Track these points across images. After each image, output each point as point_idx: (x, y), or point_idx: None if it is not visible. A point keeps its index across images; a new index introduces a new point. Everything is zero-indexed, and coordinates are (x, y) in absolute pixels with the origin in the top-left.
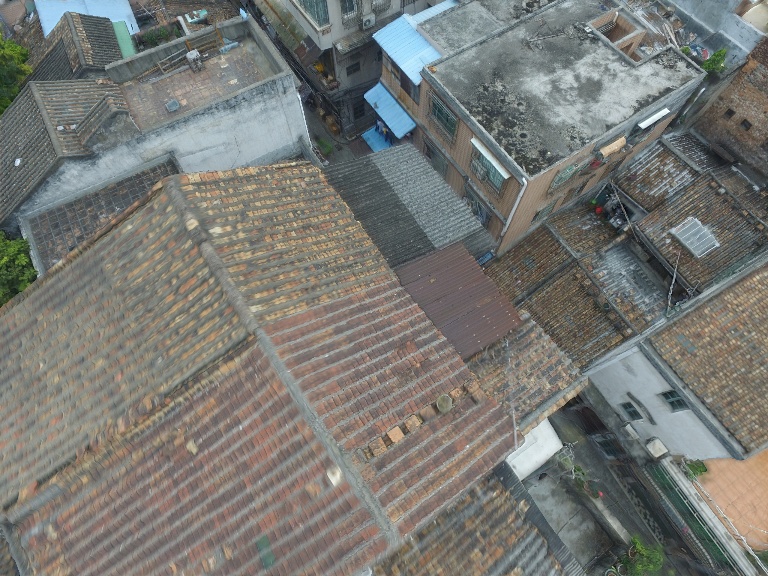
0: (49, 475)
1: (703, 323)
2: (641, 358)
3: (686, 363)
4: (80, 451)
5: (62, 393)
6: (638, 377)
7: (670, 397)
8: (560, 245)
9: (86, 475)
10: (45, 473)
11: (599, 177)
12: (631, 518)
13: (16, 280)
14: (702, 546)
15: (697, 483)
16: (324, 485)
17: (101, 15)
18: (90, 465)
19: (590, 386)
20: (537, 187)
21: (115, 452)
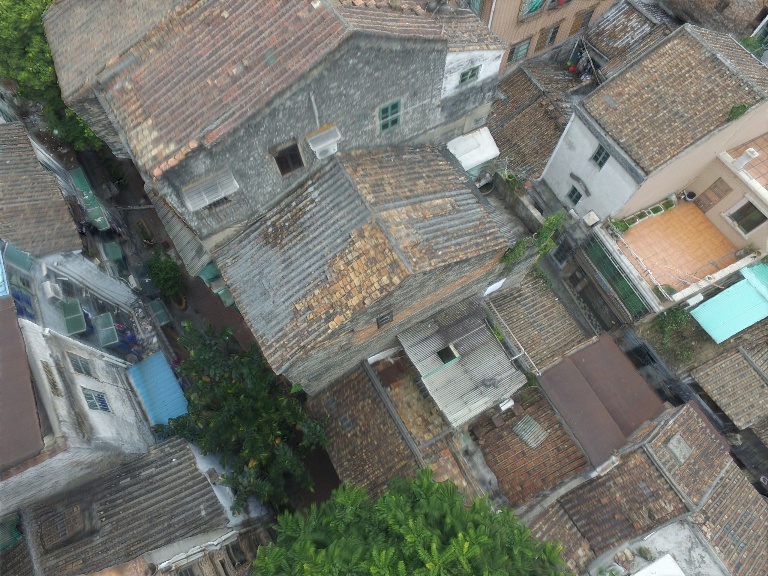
0: (127, 49)
1: (624, 84)
2: (577, 125)
3: (608, 116)
4: (149, 30)
5: (137, 4)
6: (576, 150)
7: (598, 157)
8: (531, 83)
9: (152, 47)
10: (125, 49)
11: (570, 27)
12: (577, 319)
13: None
14: (625, 306)
15: (618, 235)
16: (309, 12)
17: None
18: (156, 38)
19: (545, 187)
20: (507, 5)
21: (173, 28)
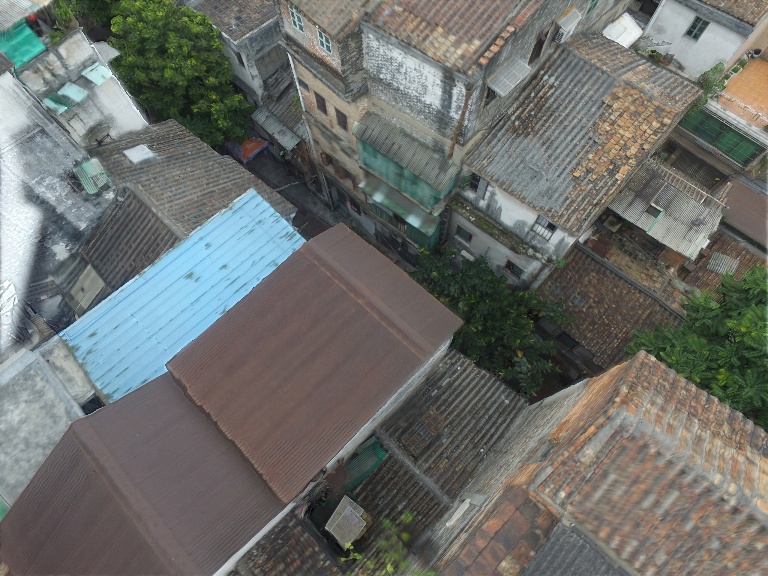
0: None
1: None
2: (669, 7)
3: None
4: None
5: None
6: (667, 31)
7: (693, 30)
8: None
9: None
10: None
11: None
12: None
13: (208, 36)
14: (731, 159)
15: (722, 93)
16: None
17: None
18: None
19: None
20: None
21: None
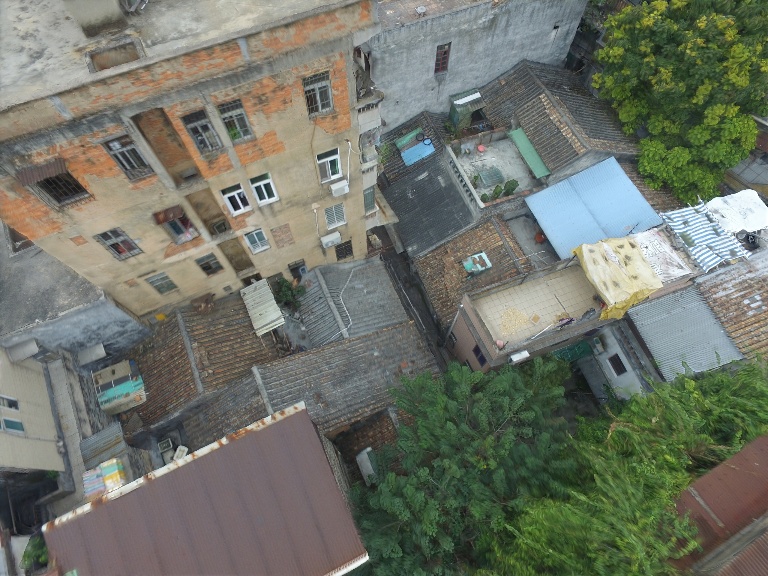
0: None
1: None
2: None
3: None
4: None
5: None
6: None
7: None
8: None
9: None
10: None
11: None
12: None
13: None
14: None
15: None
16: None
17: (578, 218)
18: None
19: None
20: None
21: None
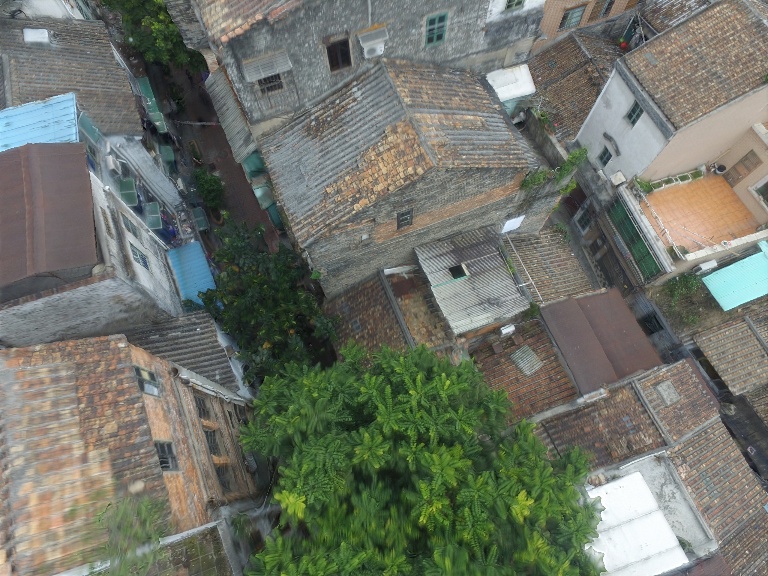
0: None
1: (668, 43)
2: (616, 82)
3: (648, 73)
4: None
5: None
6: (613, 107)
7: (633, 115)
8: (580, 50)
9: None
10: None
11: (627, 1)
12: None
13: None
14: (639, 269)
15: (641, 194)
16: None
17: None
18: None
19: (578, 149)
20: None
21: None
